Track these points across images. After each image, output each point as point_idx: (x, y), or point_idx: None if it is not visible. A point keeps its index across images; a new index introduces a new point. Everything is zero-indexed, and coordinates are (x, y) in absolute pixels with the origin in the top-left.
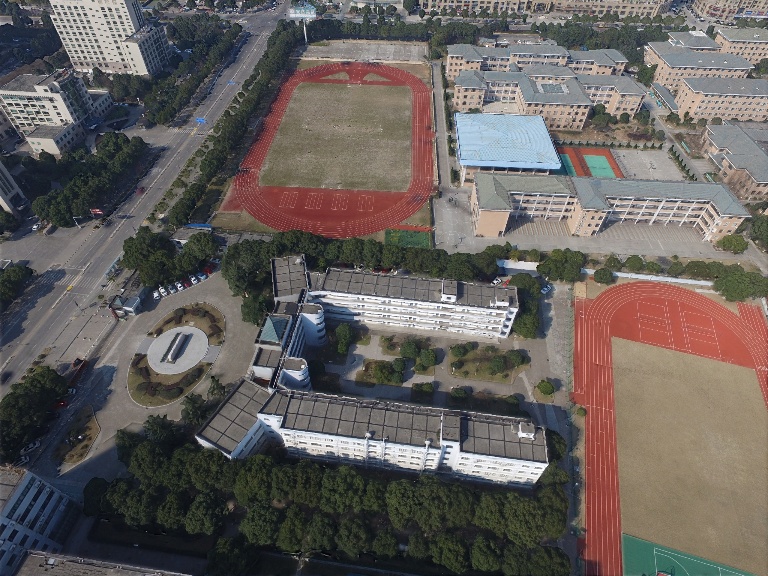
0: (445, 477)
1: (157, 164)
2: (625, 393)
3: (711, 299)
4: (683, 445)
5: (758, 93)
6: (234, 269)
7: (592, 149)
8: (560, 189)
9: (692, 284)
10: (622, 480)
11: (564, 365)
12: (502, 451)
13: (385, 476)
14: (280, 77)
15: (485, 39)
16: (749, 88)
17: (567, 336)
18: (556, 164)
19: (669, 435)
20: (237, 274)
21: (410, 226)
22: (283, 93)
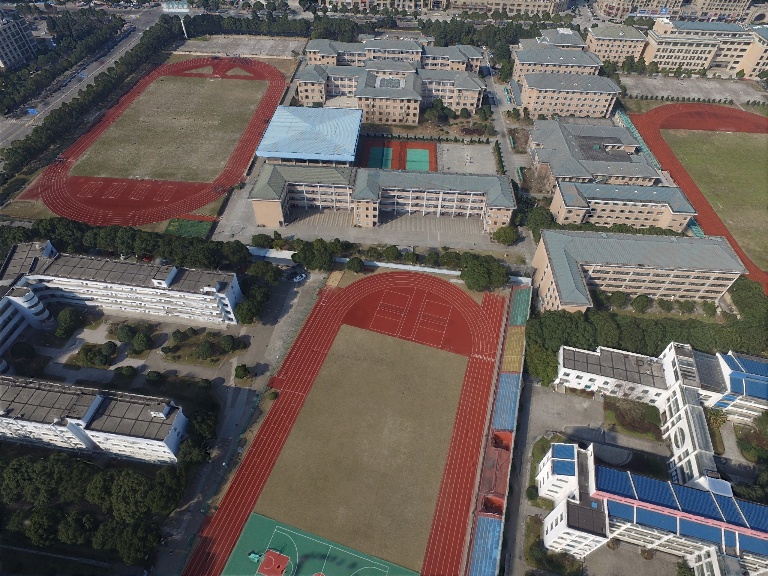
0: (103, 456)
1: None
2: (327, 378)
3: (461, 289)
4: (358, 429)
5: (590, 89)
6: None
7: (419, 143)
8: (338, 180)
9: (449, 274)
10: (279, 461)
11: (280, 351)
12: (128, 429)
13: (45, 455)
14: (143, 71)
15: (364, 35)
16: (582, 84)
17: (298, 323)
18: (349, 156)
19: (349, 419)
20: None
21: (197, 216)
22: (138, 86)
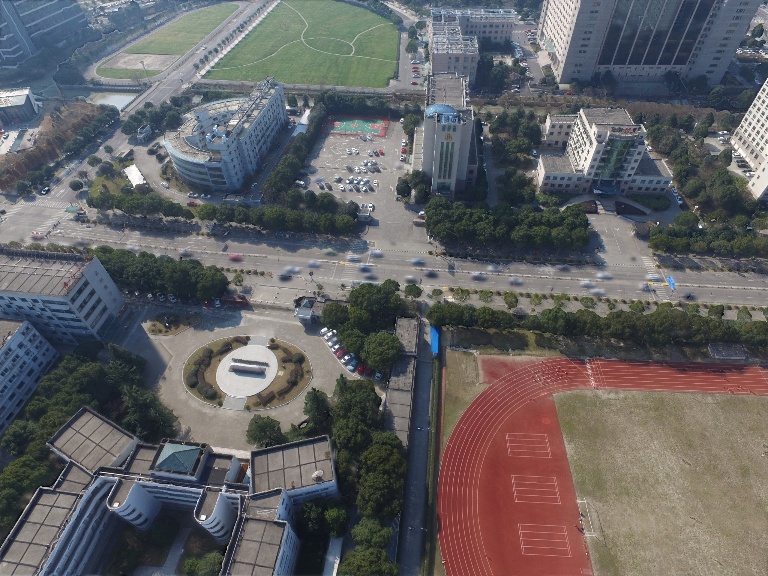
0: None
1: (562, 267)
2: None
3: None
4: None
5: None
6: (308, 393)
7: None
8: None
9: None
10: None
11: None
12: None
13: None
14: None
15: None
16: None
17: None
18: None
19: None
20: (310, 399)
21: None
22: None
